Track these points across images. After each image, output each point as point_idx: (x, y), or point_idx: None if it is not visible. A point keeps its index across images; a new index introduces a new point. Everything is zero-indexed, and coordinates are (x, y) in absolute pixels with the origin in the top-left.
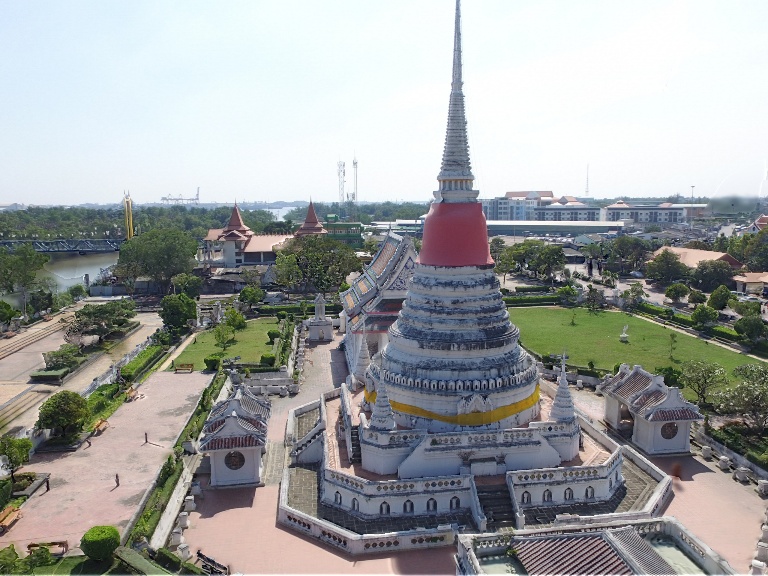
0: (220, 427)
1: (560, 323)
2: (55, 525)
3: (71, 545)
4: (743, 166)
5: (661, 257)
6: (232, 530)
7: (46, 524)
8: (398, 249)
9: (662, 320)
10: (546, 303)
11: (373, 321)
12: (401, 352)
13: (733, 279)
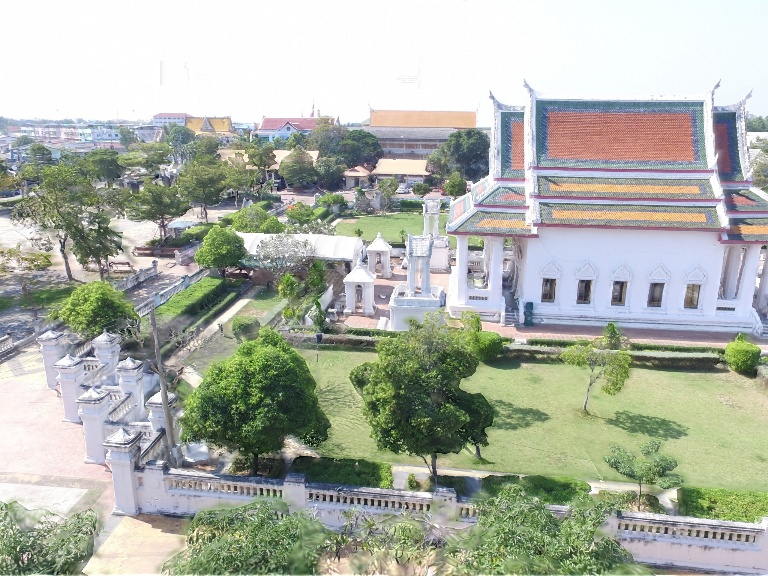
0: None
1: None
2: None
3: None
4: (139, 66)
5: (292, 157)
6: None
7: None
8: None
9: None
10: (332, 218)
11: None
12: None
13: (346, 175)
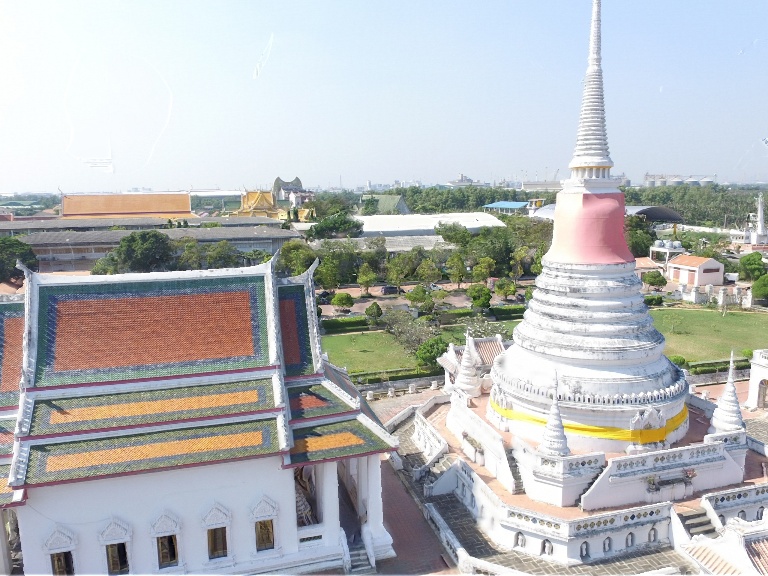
0: None
1: None
2: None
3: None
4: None
5: None
6: None
7: None
8: (274, 289)
9: None
10: None
11: None
12: None
13: None
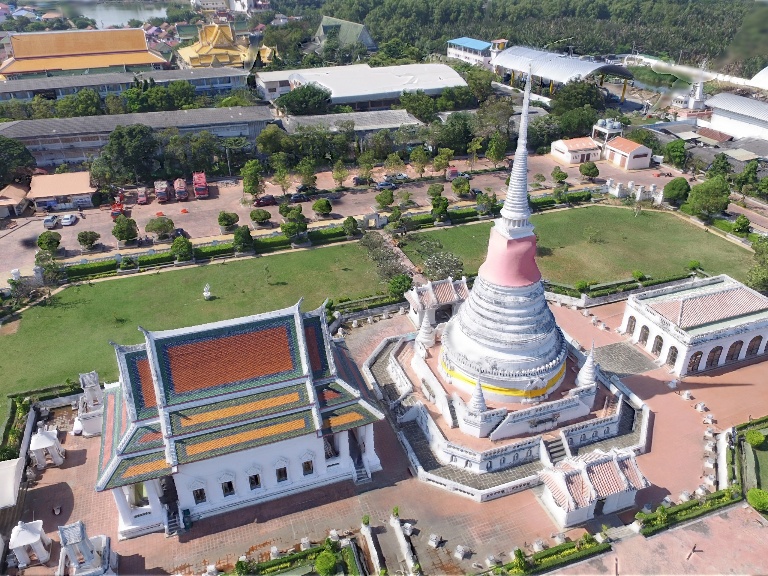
0: (629, 471)
1: (109, 329)
2: (761, 556)
3: (765, 530)
4: None
5: None
6: (670, 471)
7: (766, 563)
8: None
9: (135, 270)
10: None
11: (366, 399)
12: (546, 344)
13: None
